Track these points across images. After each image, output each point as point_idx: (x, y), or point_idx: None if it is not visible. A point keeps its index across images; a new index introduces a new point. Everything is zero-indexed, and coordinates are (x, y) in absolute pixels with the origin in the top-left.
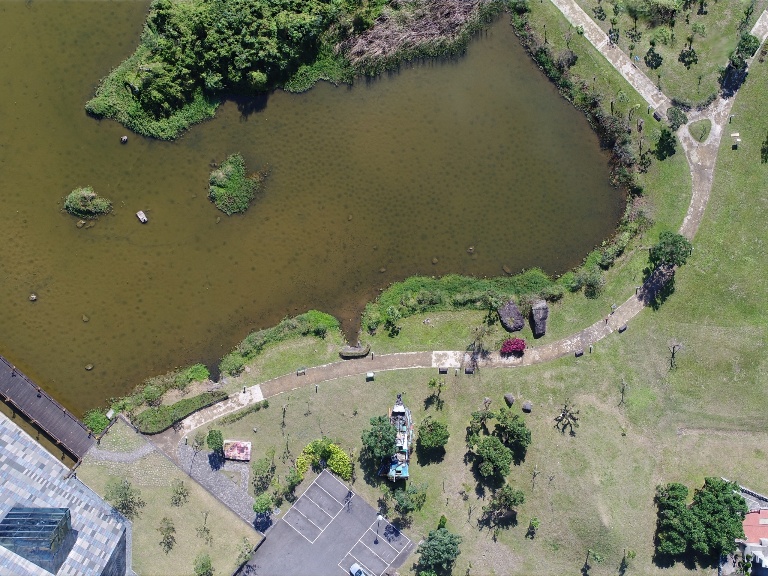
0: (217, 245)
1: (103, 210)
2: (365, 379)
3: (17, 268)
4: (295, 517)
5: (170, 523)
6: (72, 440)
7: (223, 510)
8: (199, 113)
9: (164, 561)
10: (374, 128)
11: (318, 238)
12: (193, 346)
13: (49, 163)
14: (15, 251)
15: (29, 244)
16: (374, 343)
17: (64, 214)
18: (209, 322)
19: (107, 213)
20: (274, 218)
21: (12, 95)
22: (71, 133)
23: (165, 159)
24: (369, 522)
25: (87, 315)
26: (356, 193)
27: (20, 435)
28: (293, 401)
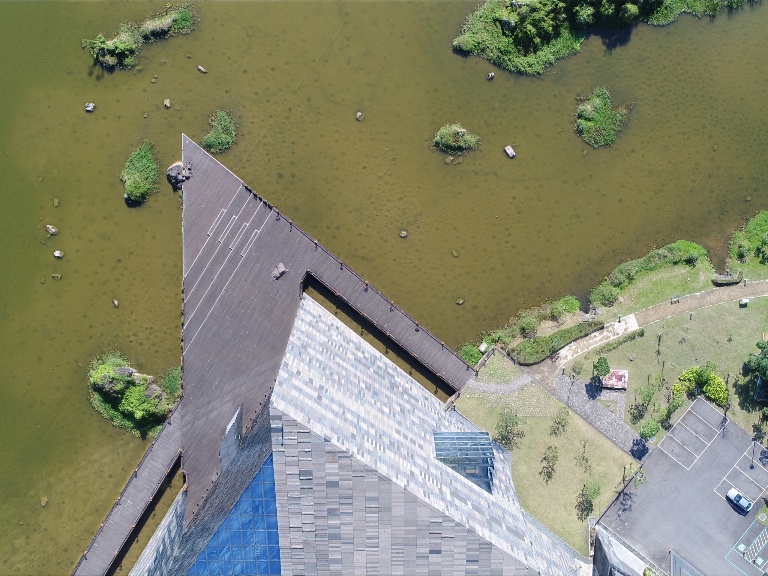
0: (584, 178)
1: (472, 146)
2: (738, 306)
3: (387, 205)
4: (671, 444)
5: (554, 452)
6: (450, 373)
7: (601, 439)
8: (565, 48)
9: (544, 490)
10: (737, 59)
11: (684, 169)
12: (562, 278)
13: (416, 101)
14: (385, 189)
15: (398, 181)
16: (745, 270)
17: (432, 151)
18: (577, 254)
19: (475, 149)
20: (640, 150)
21: (379, 35)
22: (438, 71)
23: (531, 94)
24: (744, 447)
25: (457, 250)
26: (720, 123)
27: (397, 369)
28: (668, 329)
